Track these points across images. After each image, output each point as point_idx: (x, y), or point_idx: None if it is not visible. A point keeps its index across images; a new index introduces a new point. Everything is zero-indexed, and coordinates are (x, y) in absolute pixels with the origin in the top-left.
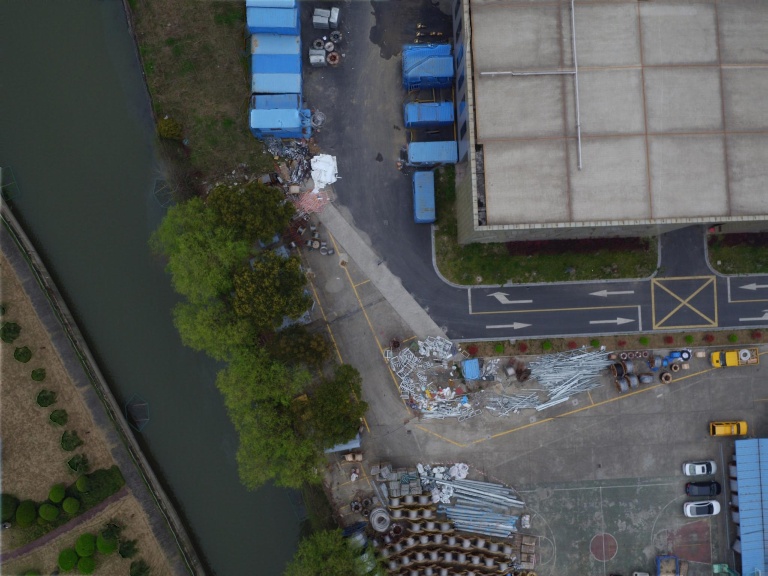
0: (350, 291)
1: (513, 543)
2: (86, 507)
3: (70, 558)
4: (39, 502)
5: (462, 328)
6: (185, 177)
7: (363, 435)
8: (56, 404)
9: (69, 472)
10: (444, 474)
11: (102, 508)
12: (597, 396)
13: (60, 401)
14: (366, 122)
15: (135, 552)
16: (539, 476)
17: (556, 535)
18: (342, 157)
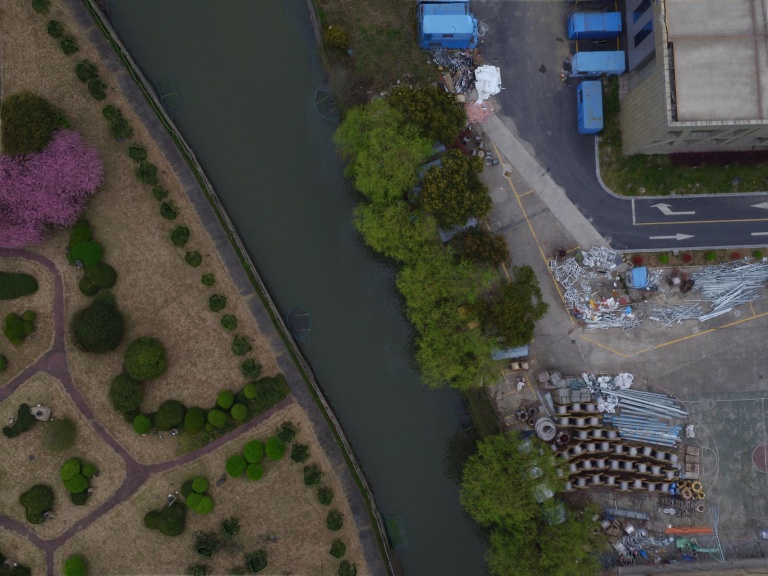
0: (514, 201)
1: (678, 453)
2: (253, 414)
3: (240, 464)
4: (206, 409)
5: (625, 239)
6: (349, 87)
7: (530, 343)
8: (222, 311)
9: (235, 379)
10: (608, 384)
11: (268, 416)
12: (758, 307)
13: (226, 308)
14: (529, 34)
15: (308, 457)
16: (702, 387)
17: (719, 446)
18: (505, 68)
